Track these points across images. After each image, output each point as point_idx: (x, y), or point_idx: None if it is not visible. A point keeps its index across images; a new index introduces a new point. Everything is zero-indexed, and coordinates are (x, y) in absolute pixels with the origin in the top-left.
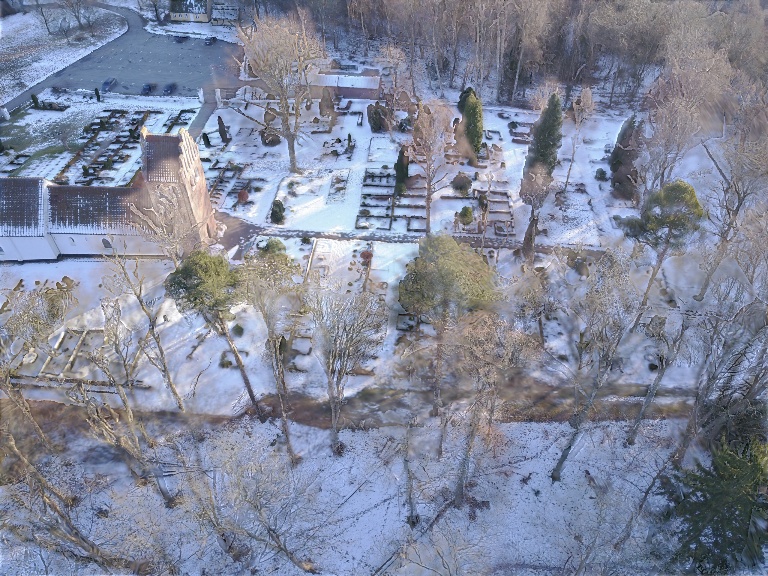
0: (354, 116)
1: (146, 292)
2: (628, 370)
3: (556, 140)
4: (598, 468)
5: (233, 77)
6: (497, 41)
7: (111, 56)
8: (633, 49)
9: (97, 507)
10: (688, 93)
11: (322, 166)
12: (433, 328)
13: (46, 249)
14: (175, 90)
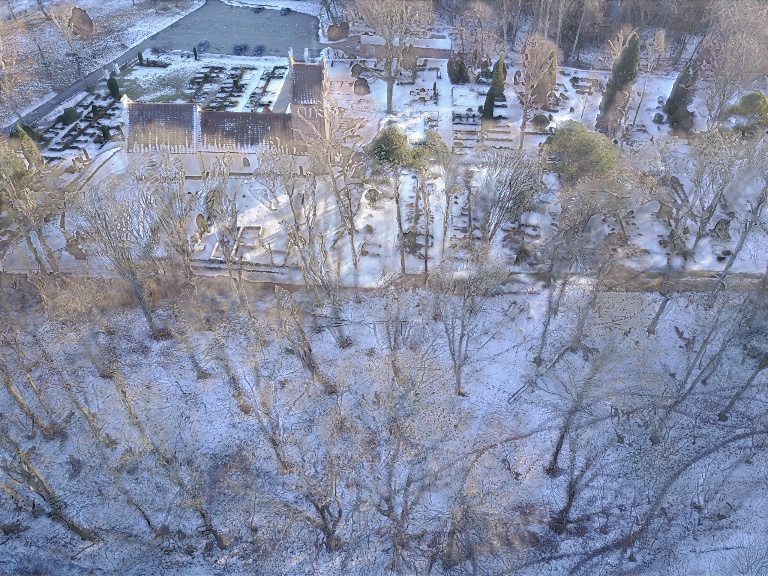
0: (432, 71)
1: (284, 201)
2: (700, 261)
3: (633, 75)
4: (685, 325)
5: (314, 41)
6: (560, 6)
7: (197, 23)
8: (681, 14)
9: (284, 347)
10: (748, 34)
11: (413, 109)
12: (532, 230)
13: (194, 166)
14: (263, 51)
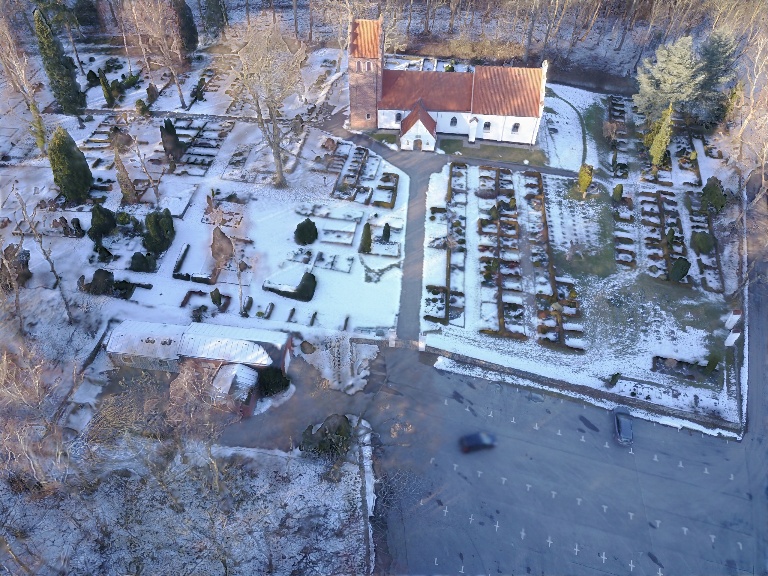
0: None
1: None
2: None
3: None
4: None
5: (383, 434)
6: None
7: None
8: None
9: None
10: None
11: (250, 187)
12: None
13: None
14: (486, 400)
